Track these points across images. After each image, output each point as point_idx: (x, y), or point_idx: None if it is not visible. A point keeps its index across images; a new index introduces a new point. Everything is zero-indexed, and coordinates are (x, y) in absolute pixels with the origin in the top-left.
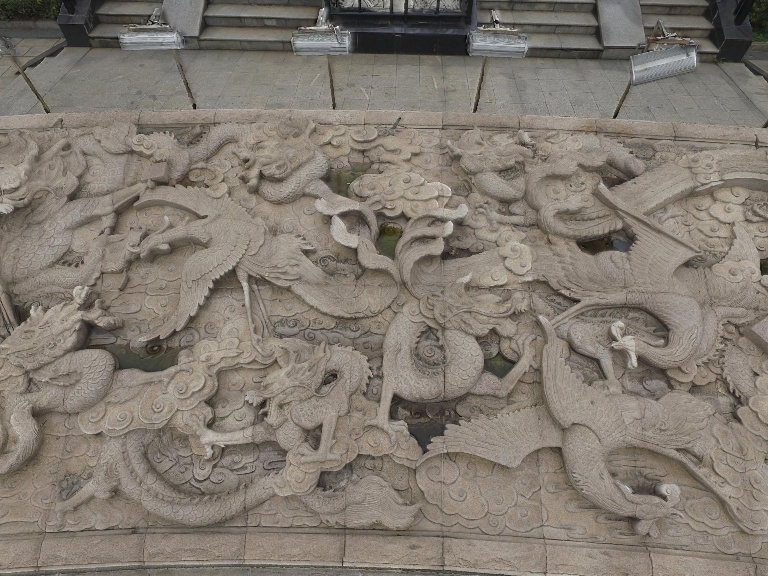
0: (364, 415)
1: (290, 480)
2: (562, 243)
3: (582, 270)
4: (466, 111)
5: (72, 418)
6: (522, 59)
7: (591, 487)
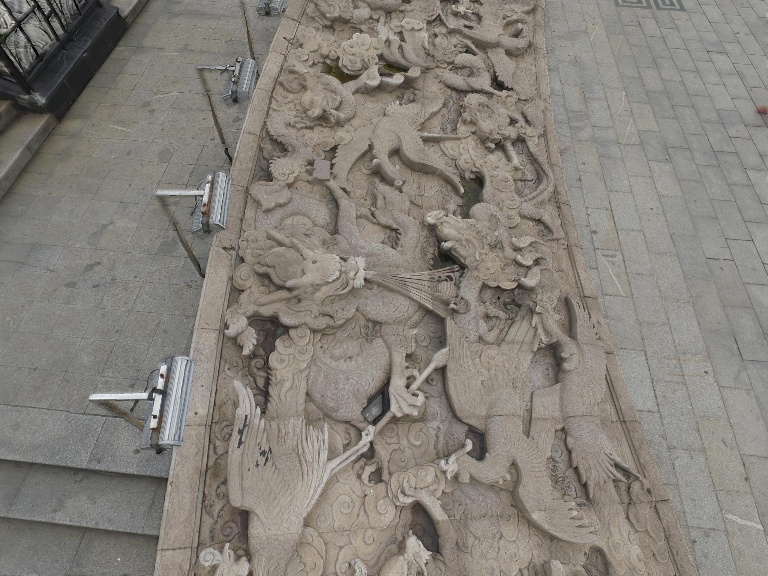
0: (500, 102)
1: (532, 135)
2: (404, 7)
3: (423, 6)
4: (222, 42)
5: (510, 233)
6: (150, 5)
7: (522, 44)
